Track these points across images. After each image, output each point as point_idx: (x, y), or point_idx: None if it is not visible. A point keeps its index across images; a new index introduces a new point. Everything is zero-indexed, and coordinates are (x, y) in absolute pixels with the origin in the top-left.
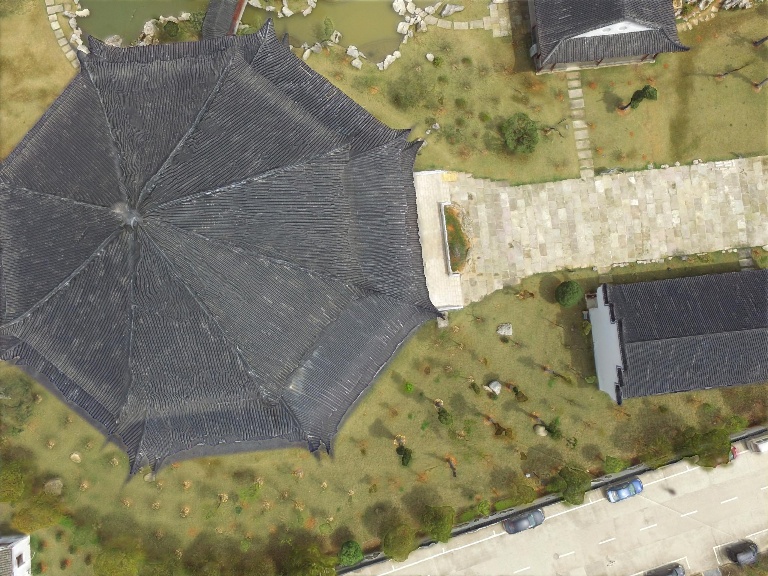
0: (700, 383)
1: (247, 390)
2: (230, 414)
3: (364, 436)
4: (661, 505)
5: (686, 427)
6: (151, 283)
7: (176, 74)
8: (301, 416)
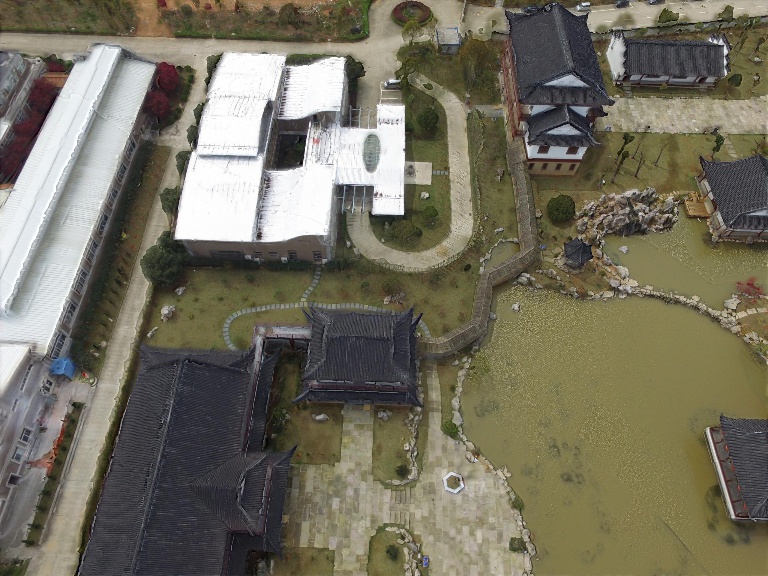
0: None
1: None
2: None
3: None
4: None
5: None
6: None
7: None
8: None
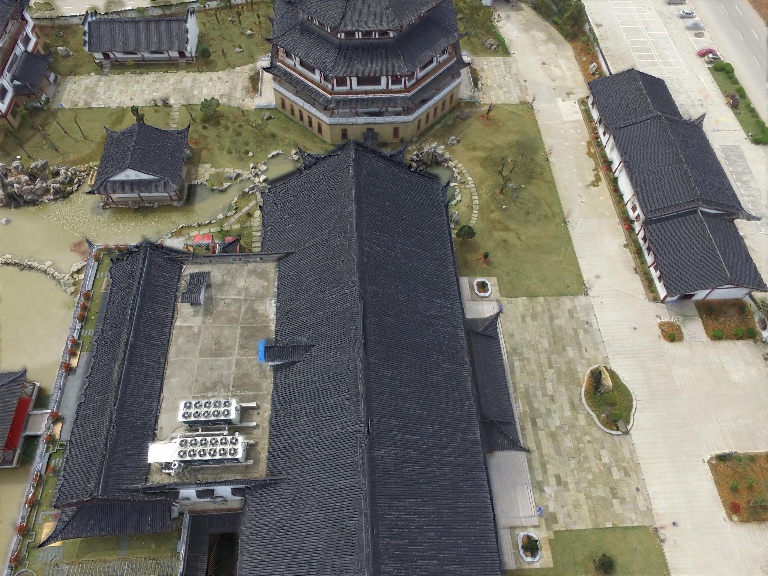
0: None
1: None
2: None
3: None
4: (183, 0)
5: None
6: None
7: None
8: None
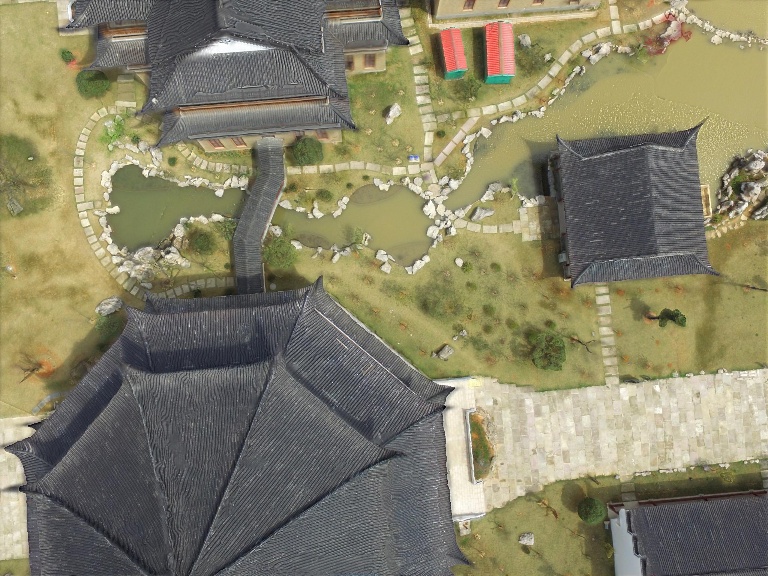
0: None
1: None
2: None
3: None
4: None
5: None
6: None
7: (218, 389)
8: None
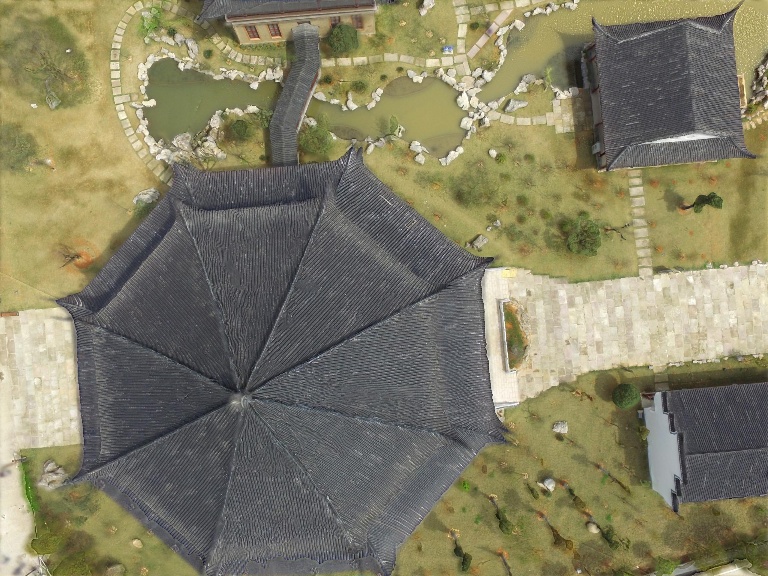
0: (755, 491)
1: (335, 537)
2: (308, 540)
3: (419, 528)
4: None
5: (736, 527)
6: (253, 447)
7: (270, 223)
8: (376, 543)
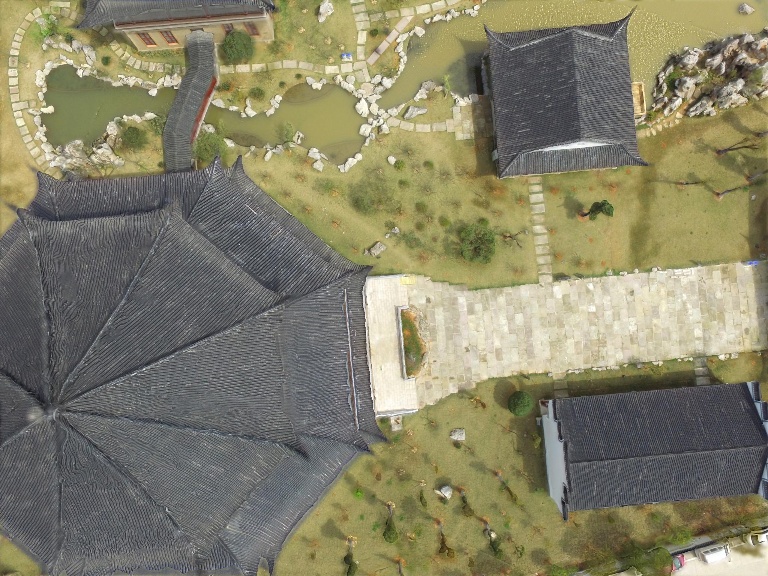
0: (647, 498)
1: (176, 549)
2: (169, 550)
3: (317, 536)
4: None
5: (635, 534)
6: (77, 460)
7: (114, 234)
8: (238, 552)
